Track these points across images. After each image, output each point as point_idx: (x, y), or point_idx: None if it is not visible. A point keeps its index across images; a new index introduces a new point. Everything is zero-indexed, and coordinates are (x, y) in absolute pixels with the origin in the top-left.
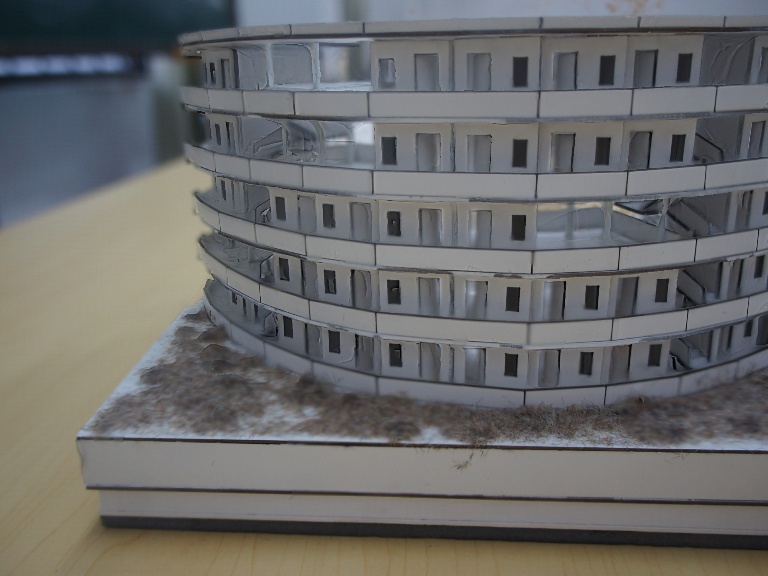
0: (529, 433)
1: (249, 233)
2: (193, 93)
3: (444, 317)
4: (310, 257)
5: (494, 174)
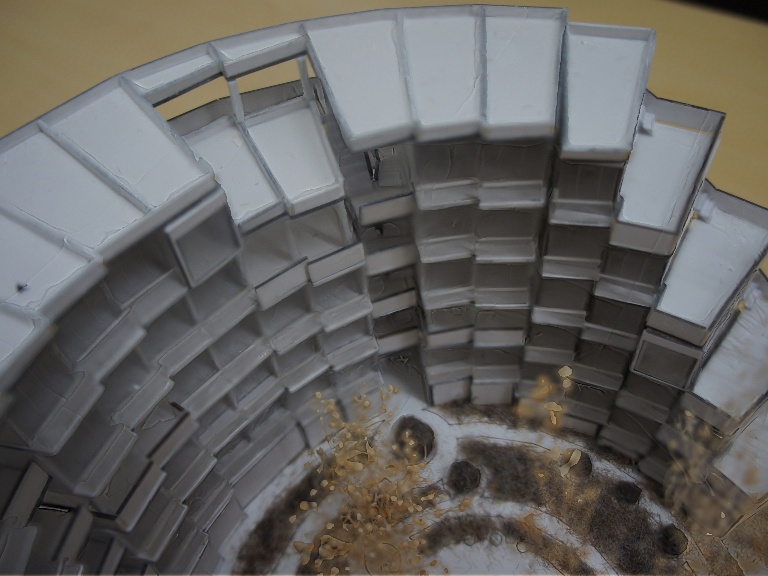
0: None
1: None
2: None
3: None
4: None
5: None
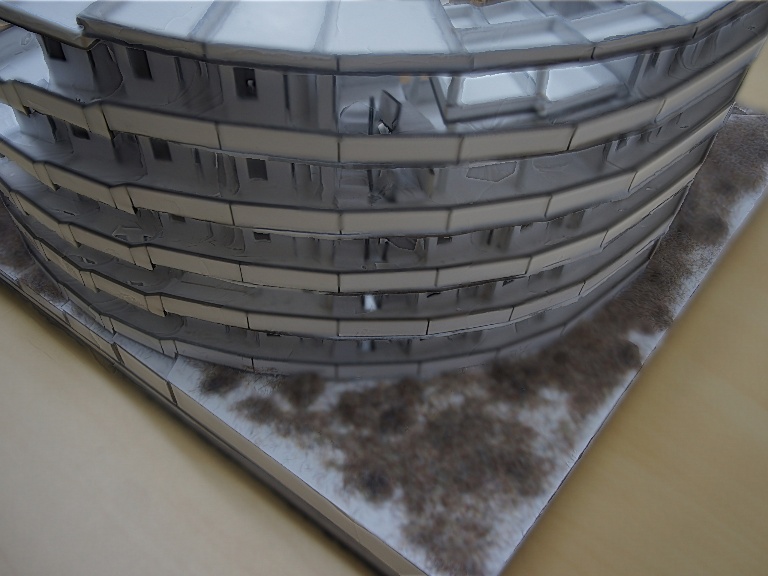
0: (673, 289)
1: (422, 282)
2: (251, 137)
3: (629, 249)
4: (530, 273)
5: (713, 120)
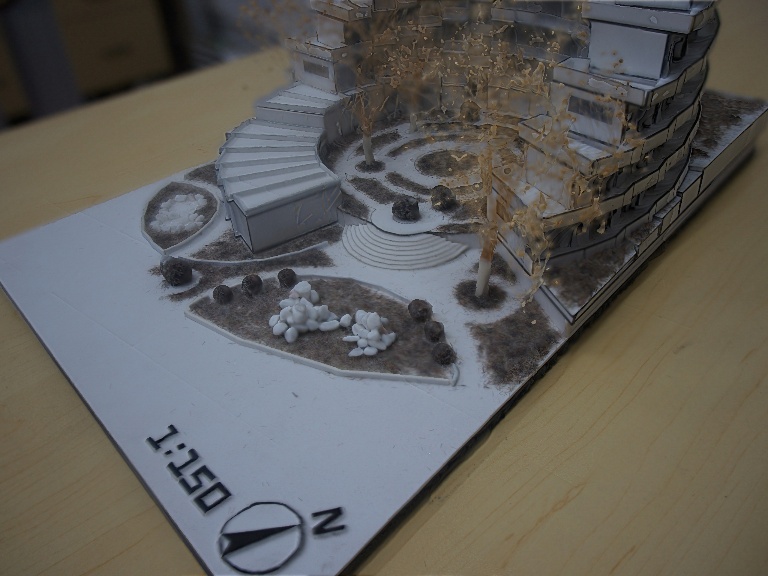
0: None
1: None
2: None
3: None
4: None
5: None
